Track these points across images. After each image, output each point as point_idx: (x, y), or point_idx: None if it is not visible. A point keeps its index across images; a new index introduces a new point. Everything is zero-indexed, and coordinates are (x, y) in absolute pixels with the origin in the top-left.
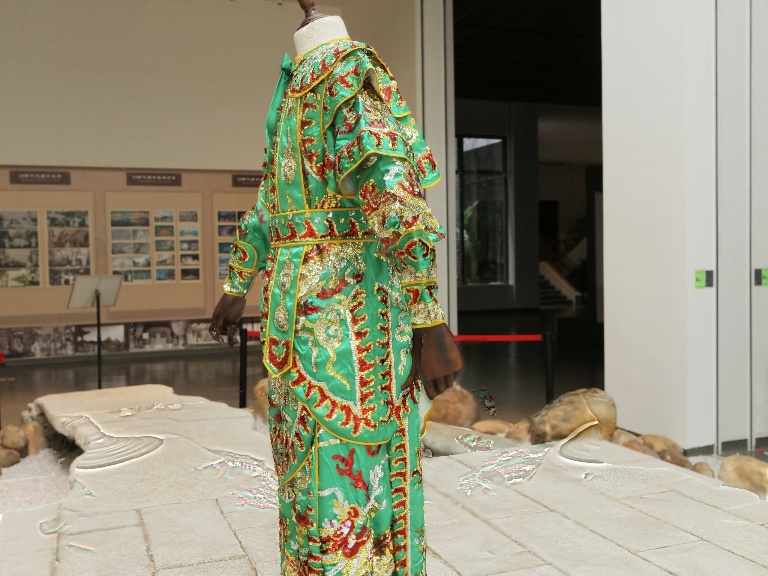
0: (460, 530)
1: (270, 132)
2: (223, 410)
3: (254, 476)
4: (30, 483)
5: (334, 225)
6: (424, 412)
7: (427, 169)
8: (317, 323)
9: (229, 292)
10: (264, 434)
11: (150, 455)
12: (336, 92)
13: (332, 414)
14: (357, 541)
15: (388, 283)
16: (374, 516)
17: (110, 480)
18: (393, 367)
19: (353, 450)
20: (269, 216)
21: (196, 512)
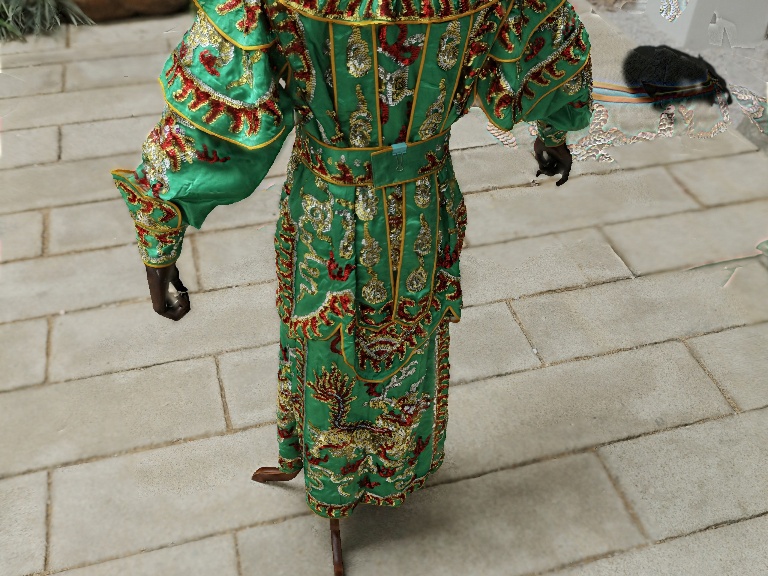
0: None
1: None
2: None
3: None
4: None
5: None
6: (354, 362)
7: None
8: None
9: None
10: None
11: None
12: None
13: None
14: None
15: (295, 216)
16: None
17: None
18: (294, 289)
19: None
20: None
21: None
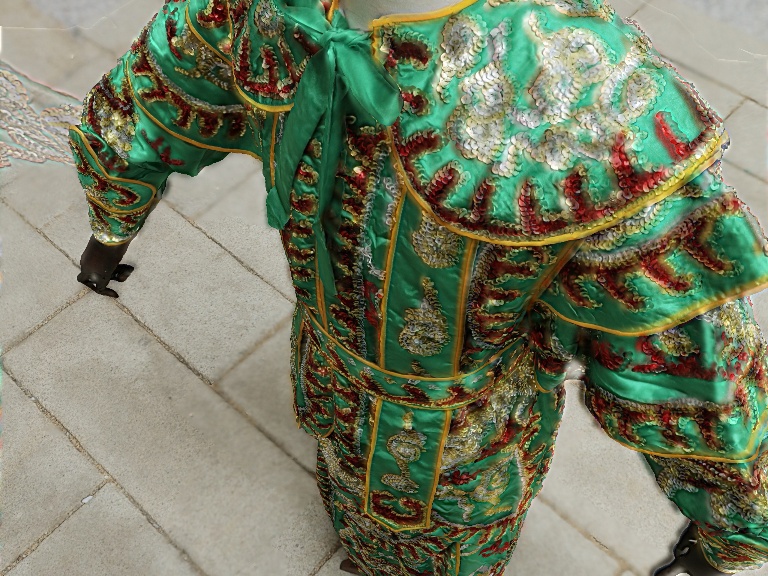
0: None
1: (326, 227)
2: None
3: None
4: None
5: (502, 368)
6: None
7: None
8: (476, 489)
9: (109, 243)
10: None
11: None
12: (643, 300)
13: (487, 538)
14: None
15: None
16: None
17: None
18: None
19: None
20: (322, 331)
21: None
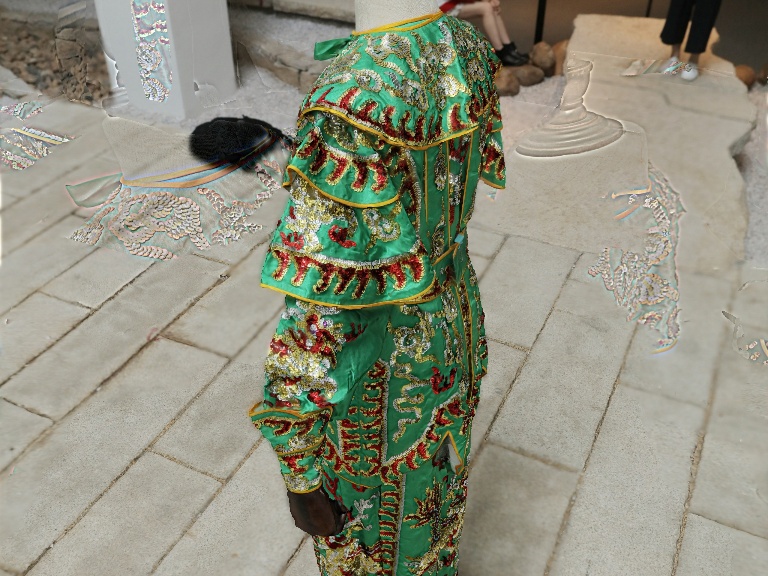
0: (766, 437)
1: None
2: (732, 99)
3: (650, 233)
4: (532, 114)
5: None
6: (455, 462)
7: (408, 276)
8: None
9: None
10: (732, 162)
11: (590, 154)
12: None
13: None
14: (336, 542)
15: (387, 356)
16: (362, 529)
17: (525, 180)
18: (385, 432)
19: (337, 479)
20: None
21: (547, 265)
